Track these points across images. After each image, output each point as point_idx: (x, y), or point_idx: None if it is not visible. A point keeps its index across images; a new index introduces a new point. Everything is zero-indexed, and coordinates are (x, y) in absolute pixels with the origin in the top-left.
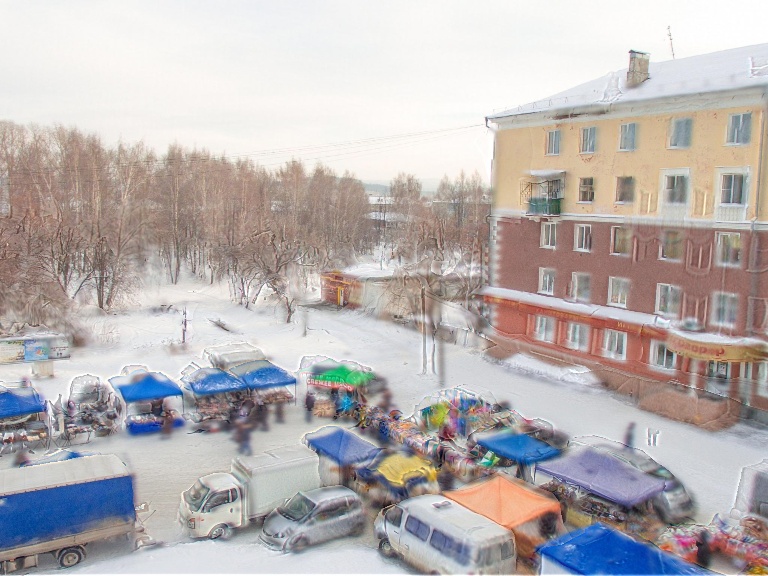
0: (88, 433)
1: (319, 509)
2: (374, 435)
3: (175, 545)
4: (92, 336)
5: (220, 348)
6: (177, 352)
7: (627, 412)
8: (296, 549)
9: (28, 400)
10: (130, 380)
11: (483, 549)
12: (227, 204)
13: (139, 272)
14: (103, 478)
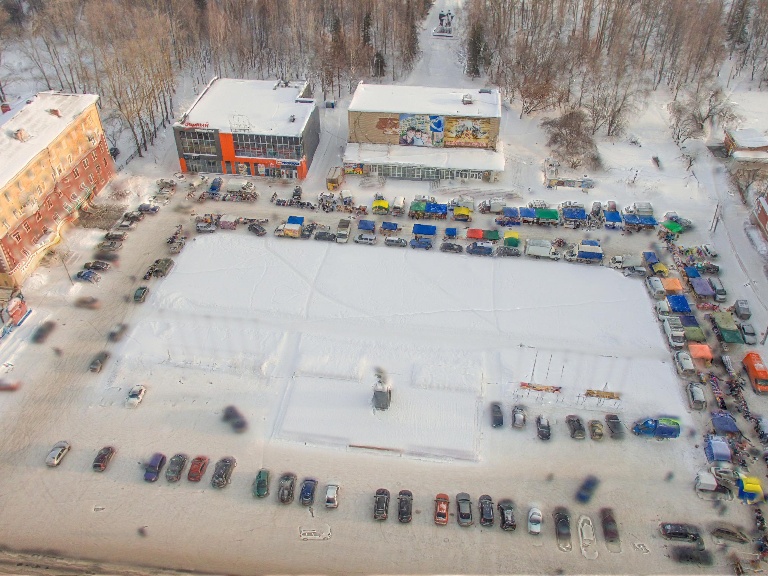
0: (596, 227)
1: (636, 271)
2: (669, 253)
3: (607, 268)
4: (602, 168)
5: (640, 204)
6: (629, 189)
7: (758, 273)
8: (629, 277)
9: (584, 216)
10: (609, 215)
11: (656, 291)
12: (702, 44)
13: (631, 111)
14: (598, 253)
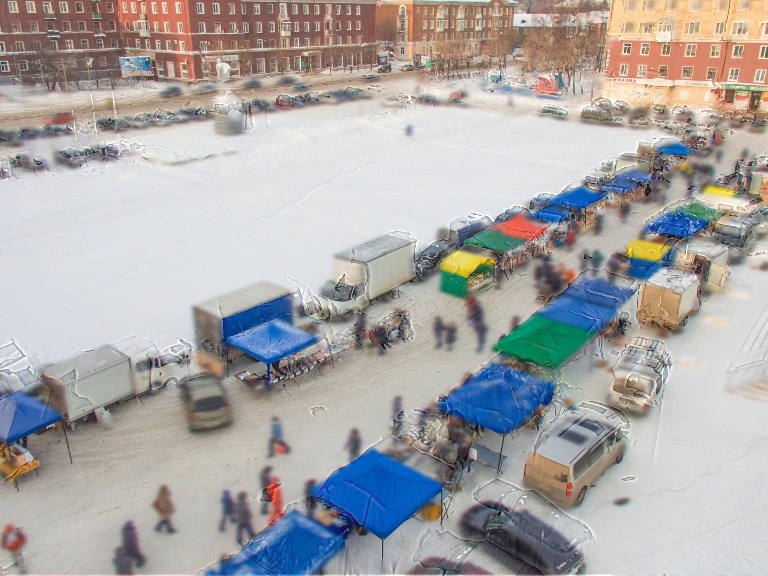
0: None
1: None
2: None
3: None
4: None
5: None
6: None
7: None
8: None
9: None
10: None
11: None
12: None
13: None
14: None
